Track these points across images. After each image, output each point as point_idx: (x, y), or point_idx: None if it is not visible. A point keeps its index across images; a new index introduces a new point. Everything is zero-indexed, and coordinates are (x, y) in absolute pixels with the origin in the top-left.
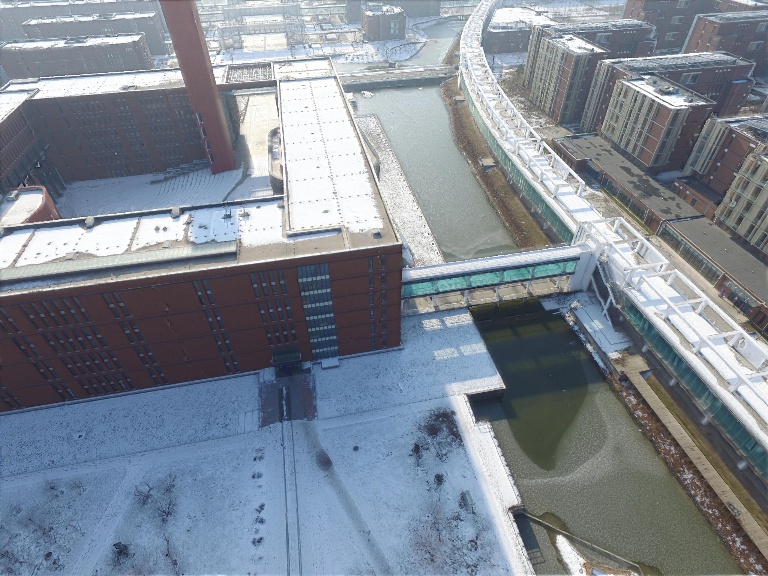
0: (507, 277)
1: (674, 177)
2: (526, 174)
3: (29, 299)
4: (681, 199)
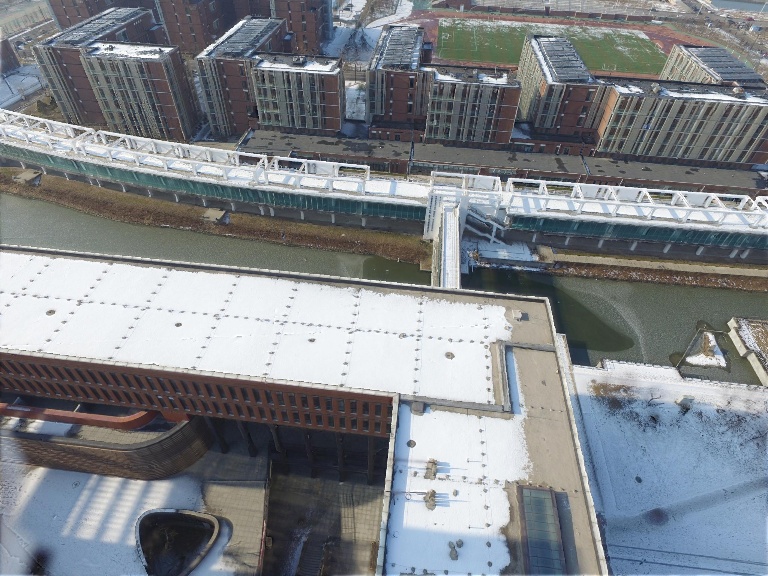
0: None
1: (351, 129)
2: (310, 193)
3: None
4: (386, 141)
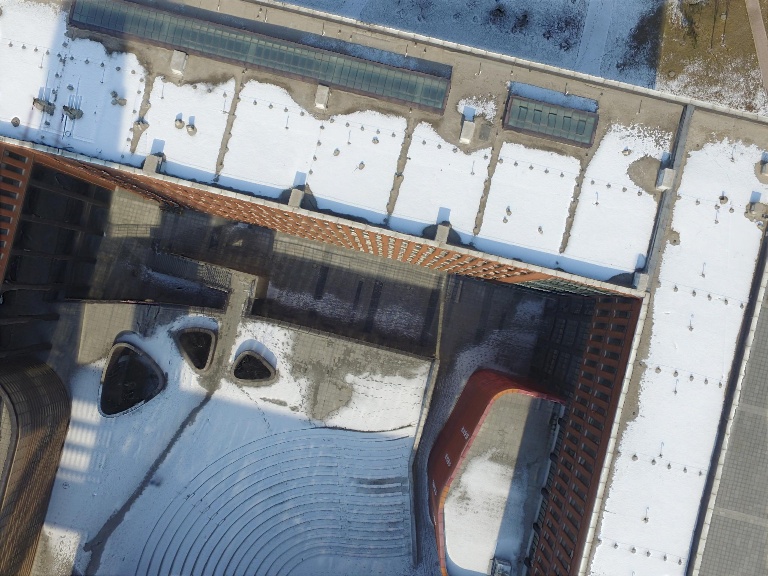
0: None
1: None
2: None
3: None
4: None
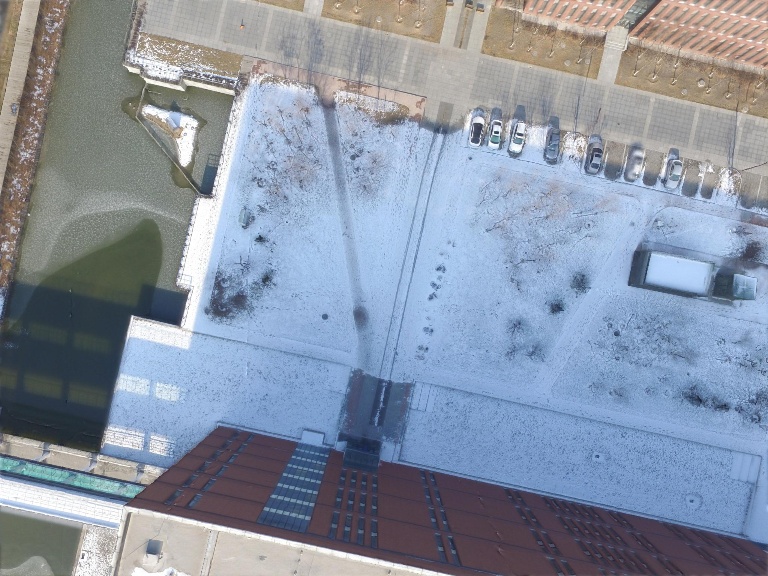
0: (9, 467)
1: None
2: None
3: None
4: None
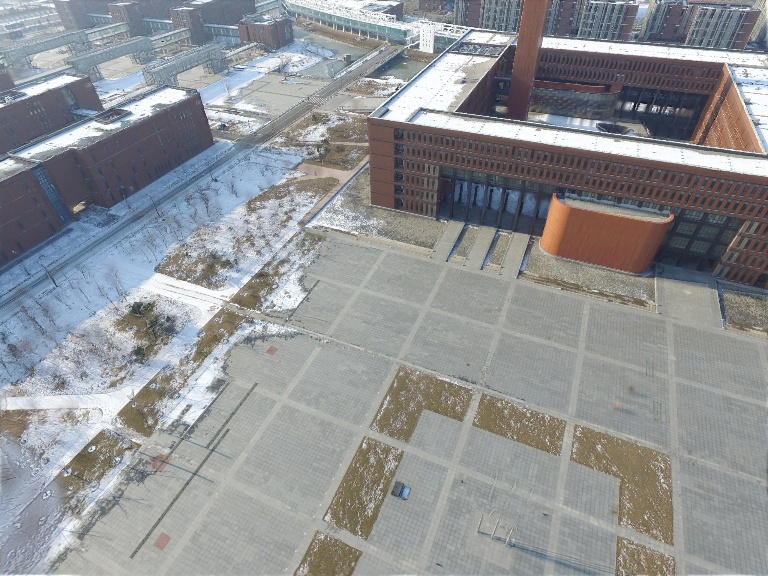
0: None
1: None
2: None
3: None
4: None
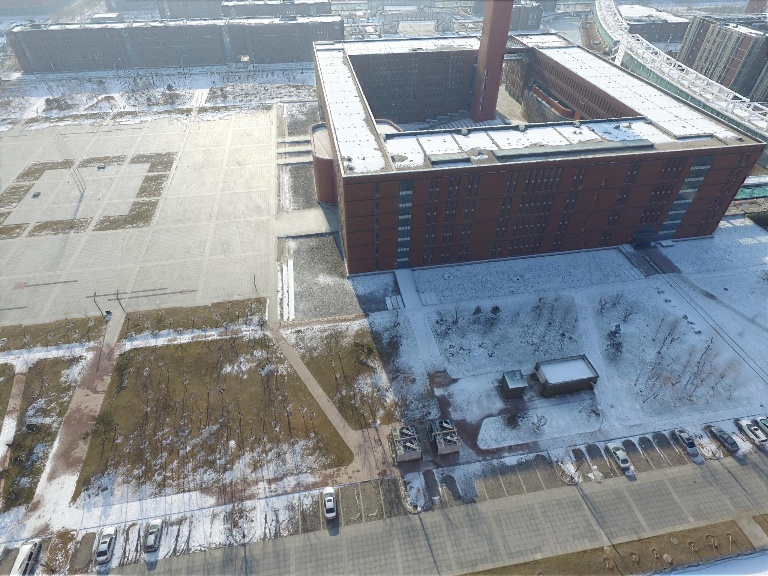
0: None
1: None
2: (749, 125)
3: (537, 167)
4: None
